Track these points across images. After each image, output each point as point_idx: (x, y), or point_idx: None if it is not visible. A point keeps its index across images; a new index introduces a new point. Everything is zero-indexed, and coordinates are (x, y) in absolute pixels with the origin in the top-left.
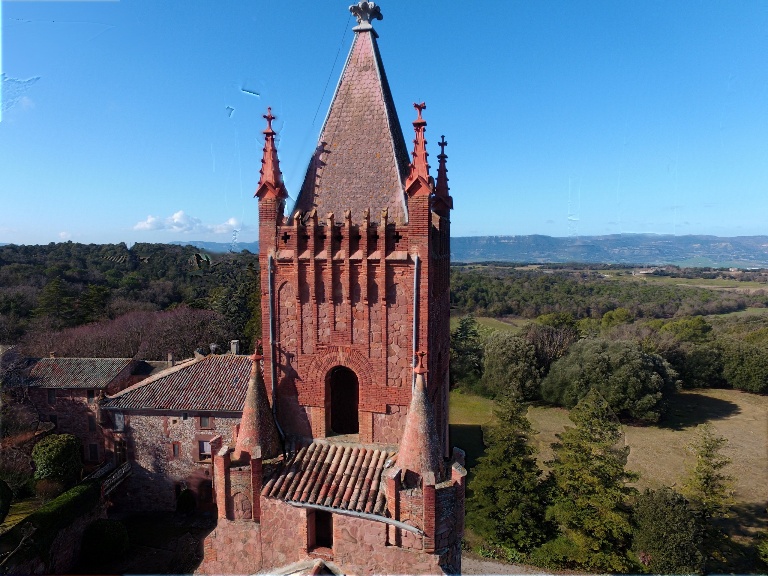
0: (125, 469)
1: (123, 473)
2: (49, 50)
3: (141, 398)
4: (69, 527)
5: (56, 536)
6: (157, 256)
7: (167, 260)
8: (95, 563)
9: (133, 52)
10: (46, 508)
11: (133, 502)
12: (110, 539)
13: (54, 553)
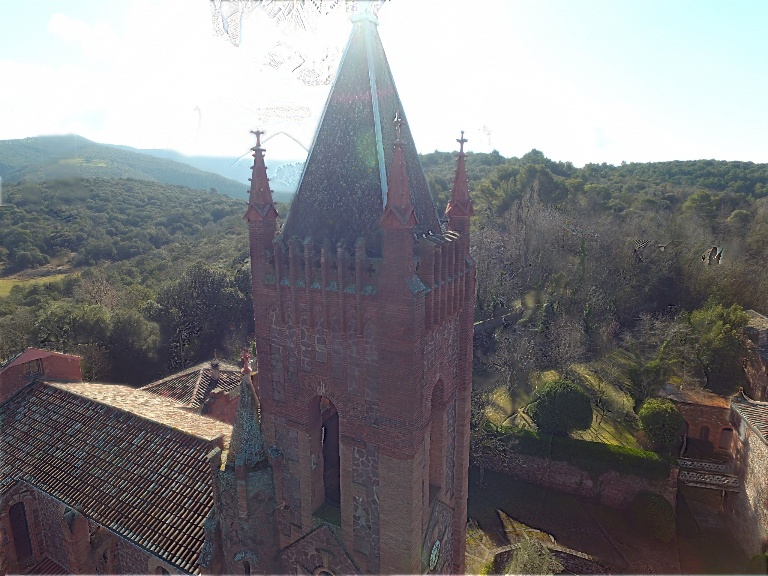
0: (730, 481)
1: (725, 483)
2: (292, 149)
3: (767, 417)
4: (624, 475)
5: (608, 472)
6: (673, 245)
7: (680, 251)
8: (630, 522)
9: (528, 58)
10: (615, 447)
11: (734, 523)
12: (646, 515)
13: (603, 483)
